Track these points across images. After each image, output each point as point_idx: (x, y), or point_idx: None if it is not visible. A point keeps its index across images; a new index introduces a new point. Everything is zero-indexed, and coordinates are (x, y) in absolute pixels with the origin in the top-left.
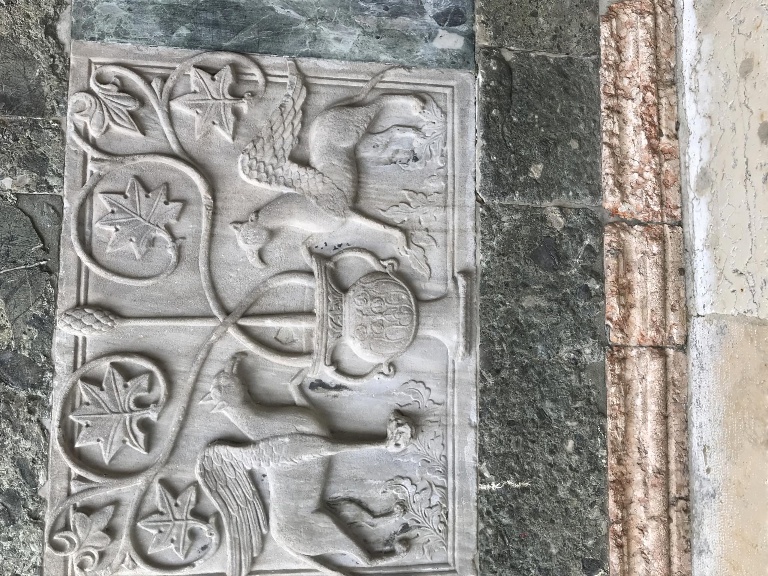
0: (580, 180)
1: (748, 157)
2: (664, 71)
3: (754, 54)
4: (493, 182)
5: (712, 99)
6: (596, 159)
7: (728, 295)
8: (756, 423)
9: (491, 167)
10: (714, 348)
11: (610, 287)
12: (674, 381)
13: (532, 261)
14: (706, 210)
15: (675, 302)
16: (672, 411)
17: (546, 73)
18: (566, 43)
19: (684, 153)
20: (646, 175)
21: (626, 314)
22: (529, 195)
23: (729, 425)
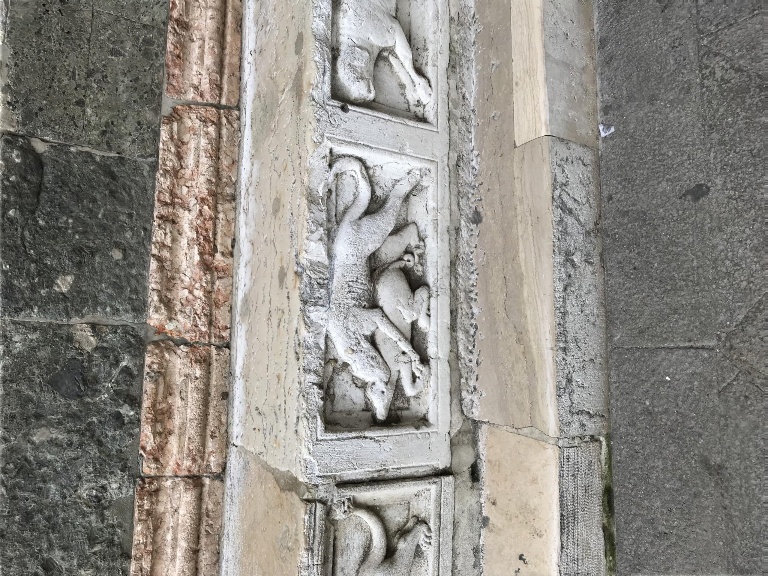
0: (121, 294)
1: (271, 297)
2: (225, 184)
3: (281, 195)
4: (3, 295)
5: (255, 227)
6: (143, 271)
7: (251, 432)
8: (258, 570)
9: (2, 277)
10: (240, 482)
11: (145, 414)
12: (208, 512)
13: (50, 387)
14: (244, 338)
15: (215, 428)
16: (203, 544)
17: (88, 172)
18: (118, 141)
19: (236, 273)
20: (196, 293)
21: (163, 441)
22: (52, 311)
23: (243, 566)
